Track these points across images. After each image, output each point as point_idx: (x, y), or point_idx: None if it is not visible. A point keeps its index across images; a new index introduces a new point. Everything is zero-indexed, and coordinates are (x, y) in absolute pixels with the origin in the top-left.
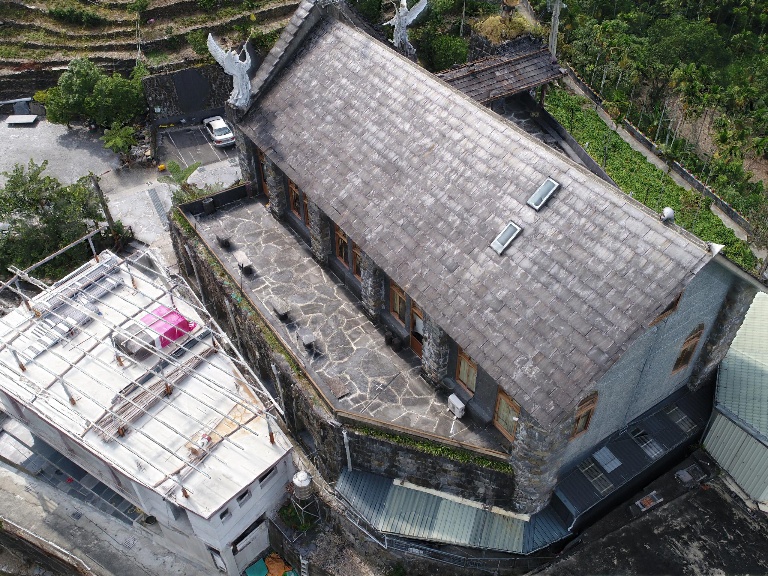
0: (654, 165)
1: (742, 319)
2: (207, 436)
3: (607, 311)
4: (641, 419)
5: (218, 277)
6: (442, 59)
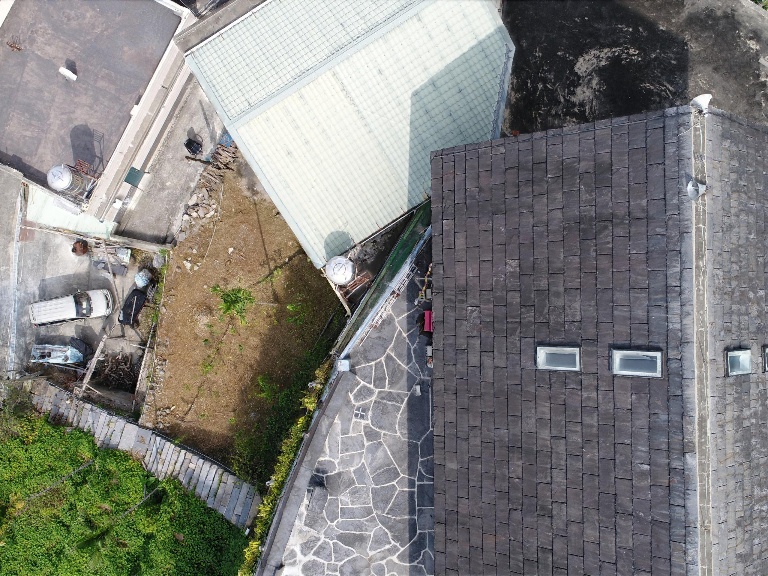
0: None
1: None
2: None
3: None
4: None
5: None
6: None
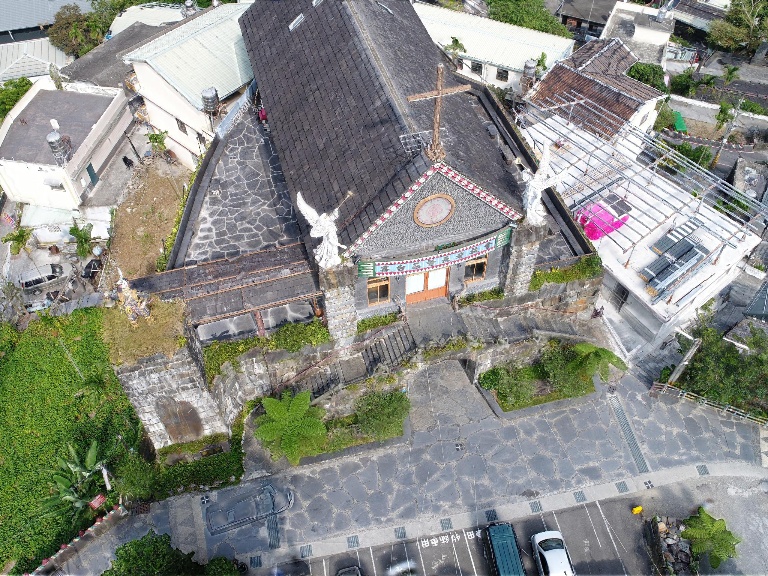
0: None
1: None
2: (558, 142)
3: None
4: None
5: (553, 186)
6: (165, 540)
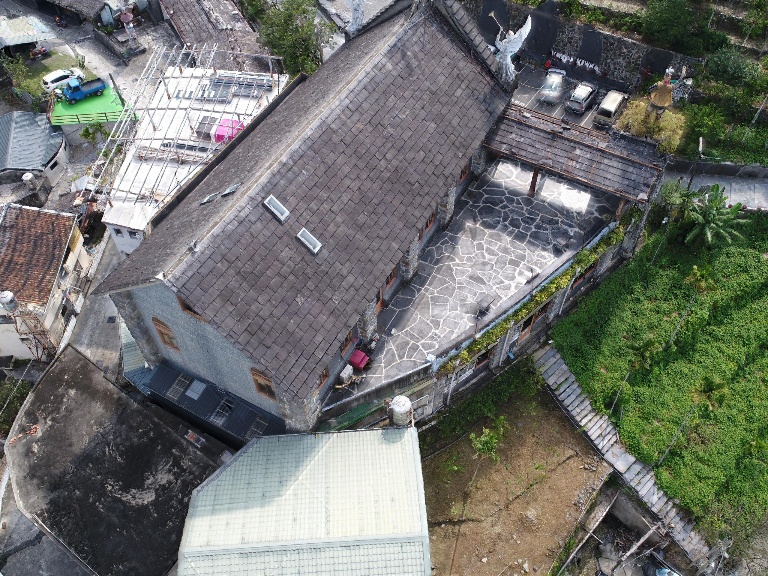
0: None
1: (301, 407)
2: None
3: (145, 266)
4: (239, 400)
5: None
6: None
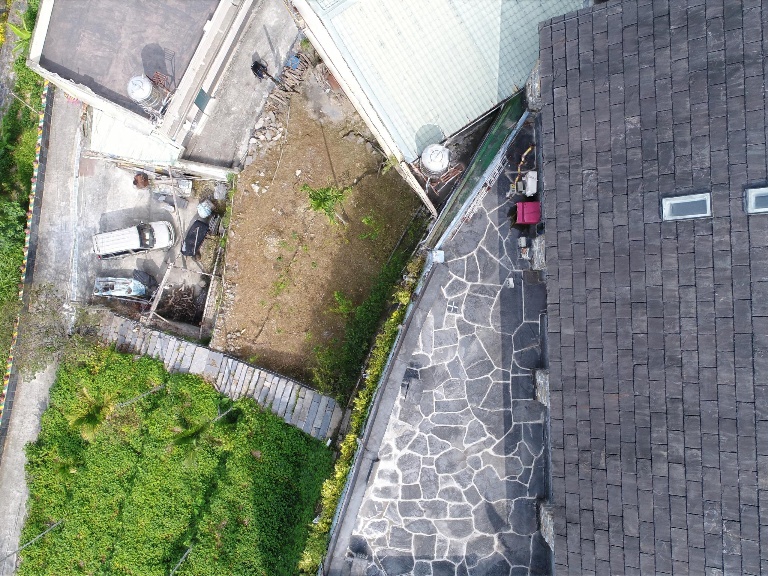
0: (18, 571)
1: None
2: None
3: None
4: None
5: None
6: None
